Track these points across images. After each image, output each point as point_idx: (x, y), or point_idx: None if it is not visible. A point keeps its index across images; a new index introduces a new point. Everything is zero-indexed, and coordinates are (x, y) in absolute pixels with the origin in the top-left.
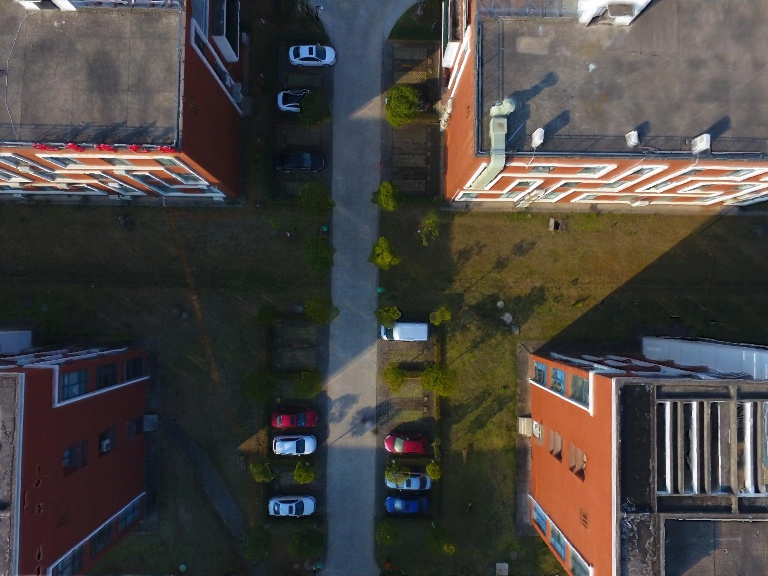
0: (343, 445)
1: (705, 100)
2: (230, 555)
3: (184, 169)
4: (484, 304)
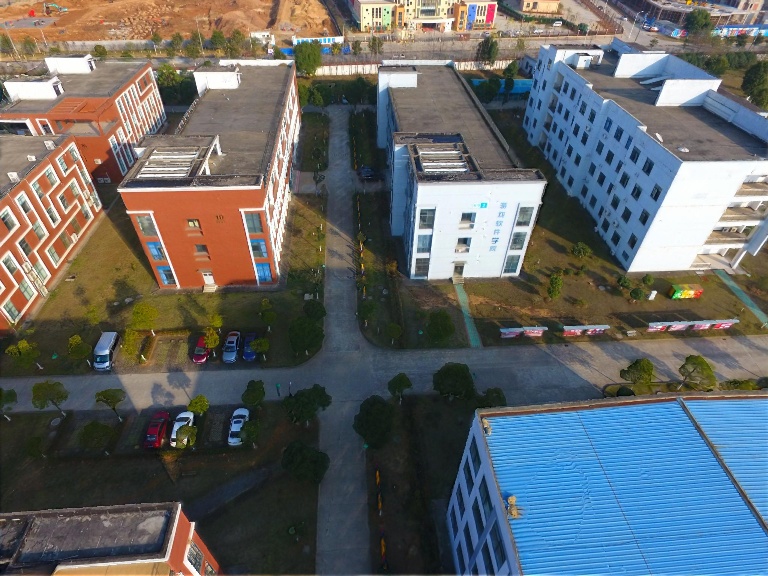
0: (196, 394)
1: None
2: (282, 481)
3: None
4: (111, 311)
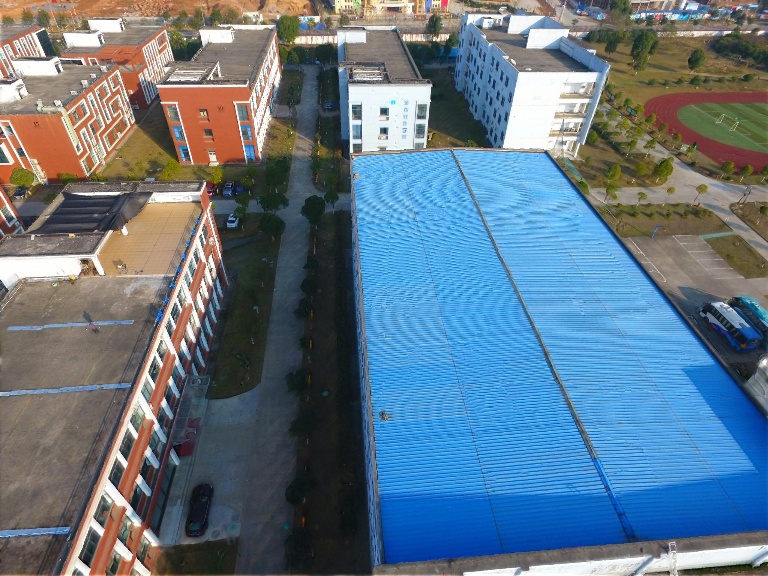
0: None
1: (70, 85)
2: None
3: (0, 199)
4: (148, 173)
